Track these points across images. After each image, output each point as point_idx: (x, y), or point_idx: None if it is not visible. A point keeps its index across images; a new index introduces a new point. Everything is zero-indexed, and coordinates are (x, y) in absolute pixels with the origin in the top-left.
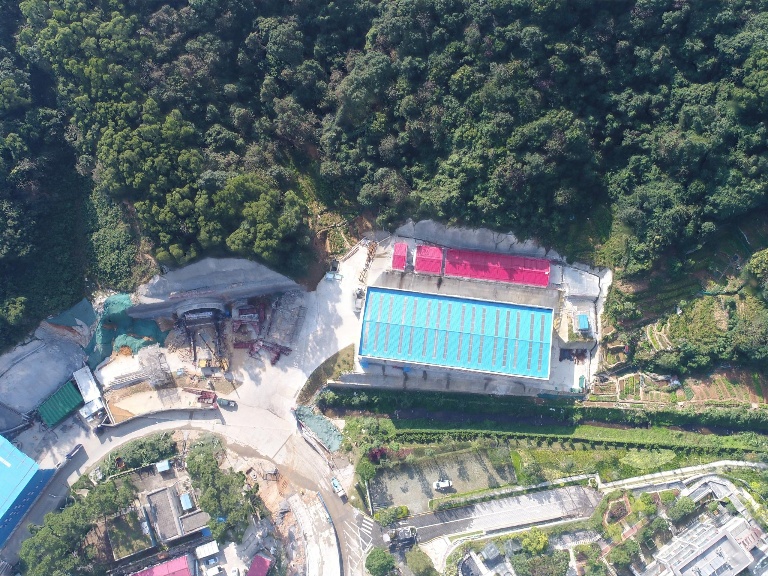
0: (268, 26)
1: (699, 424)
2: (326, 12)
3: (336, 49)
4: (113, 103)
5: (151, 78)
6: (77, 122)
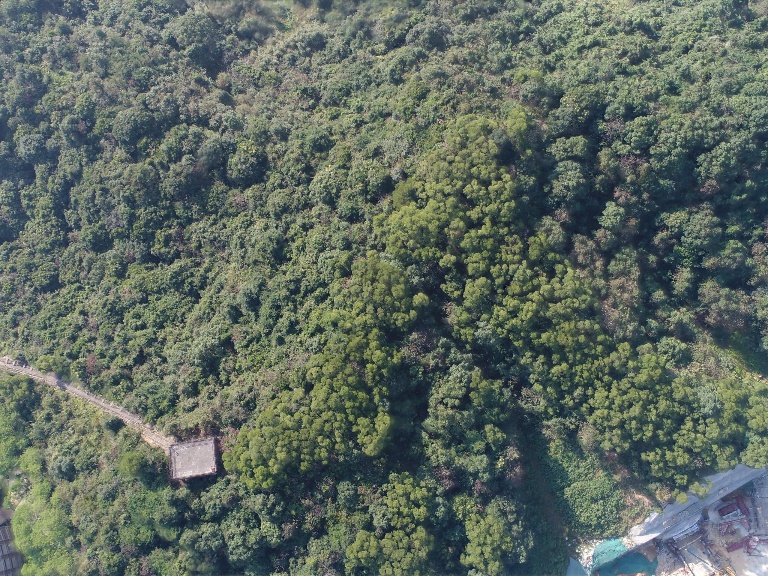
0: (680, 221)
1: None
2: (741, 191)
3: (752, 222)
4: (592, 361)
5: (613, 320)
6: (545, 389)
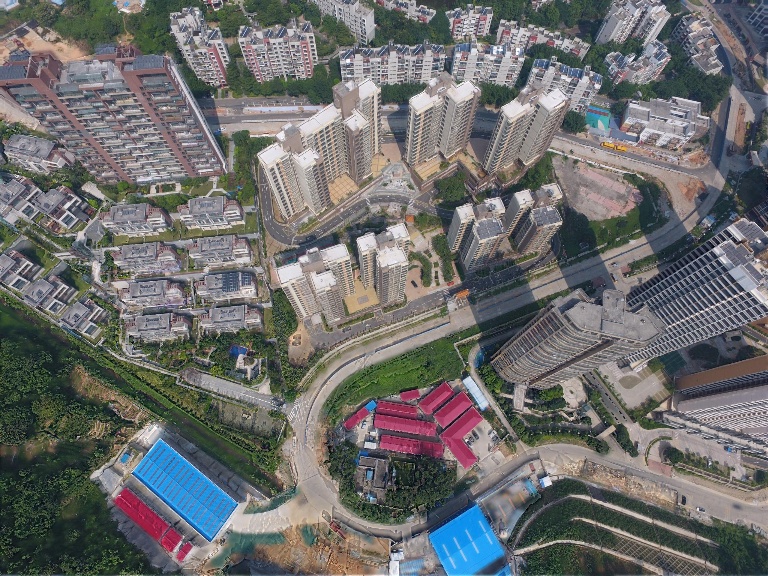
0: None
1: (117, 380)
2: None
3: None
4: None
5: None
6: None
